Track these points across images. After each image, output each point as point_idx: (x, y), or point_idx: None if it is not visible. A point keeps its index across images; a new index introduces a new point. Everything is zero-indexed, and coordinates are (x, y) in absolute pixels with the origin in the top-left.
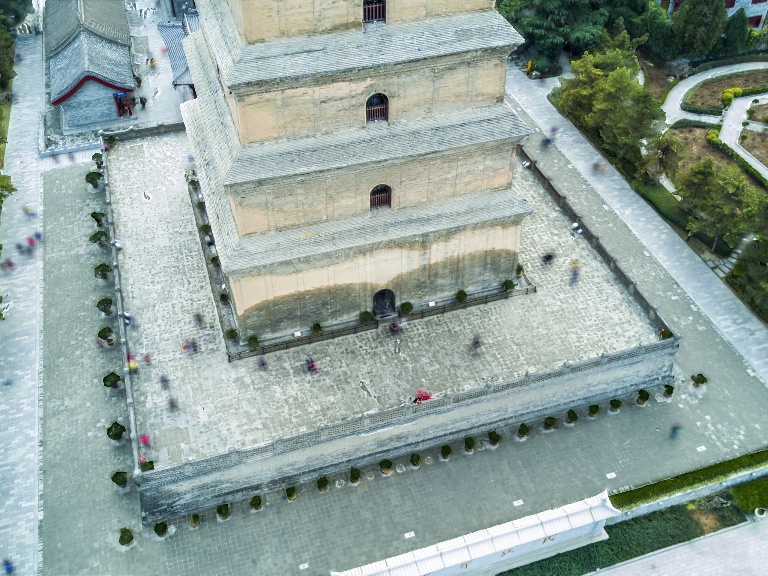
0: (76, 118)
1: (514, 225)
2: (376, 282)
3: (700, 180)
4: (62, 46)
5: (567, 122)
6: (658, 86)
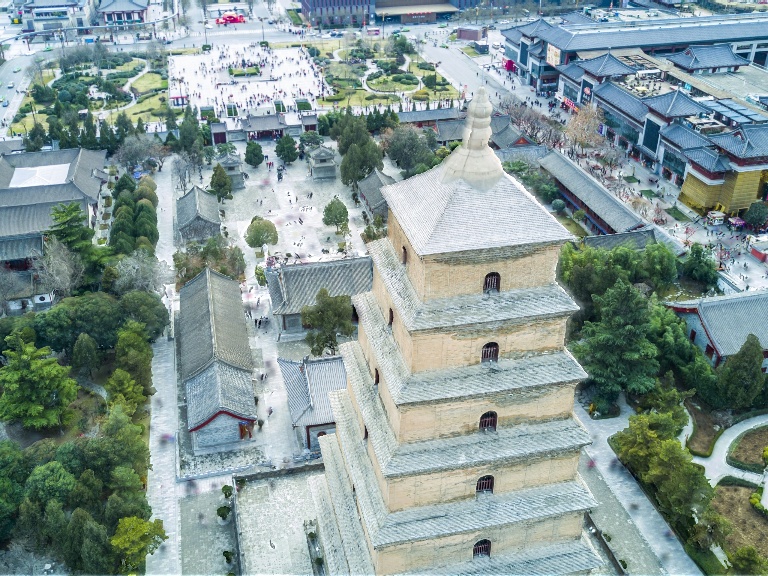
0: (206, 440)
1: None
2: None
3: (745, 566)
4: (198, 372)
5: (626, 471)
6: (705, 435)
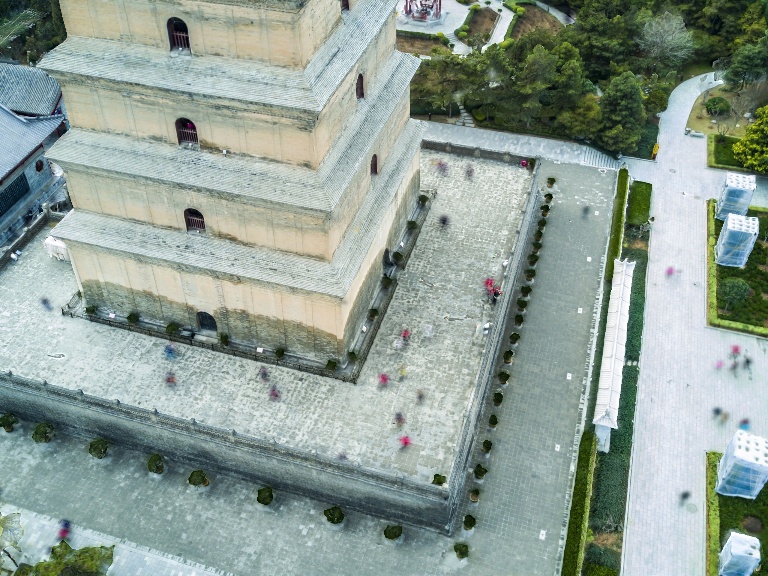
0: None
1: None
2: (383, 247)
3: (420, 71)
4: None
5: None
6: None
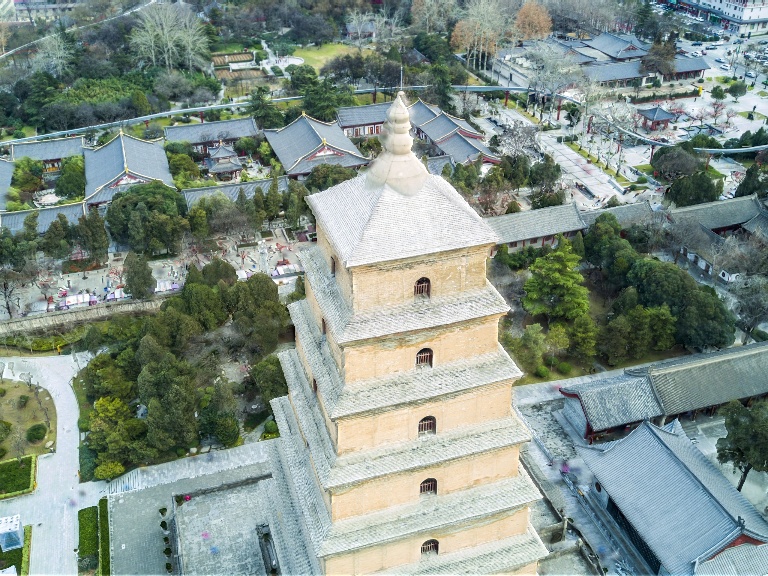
0: None
1: None
2: None
3: None
4: (635, 373)
5: None
6: None
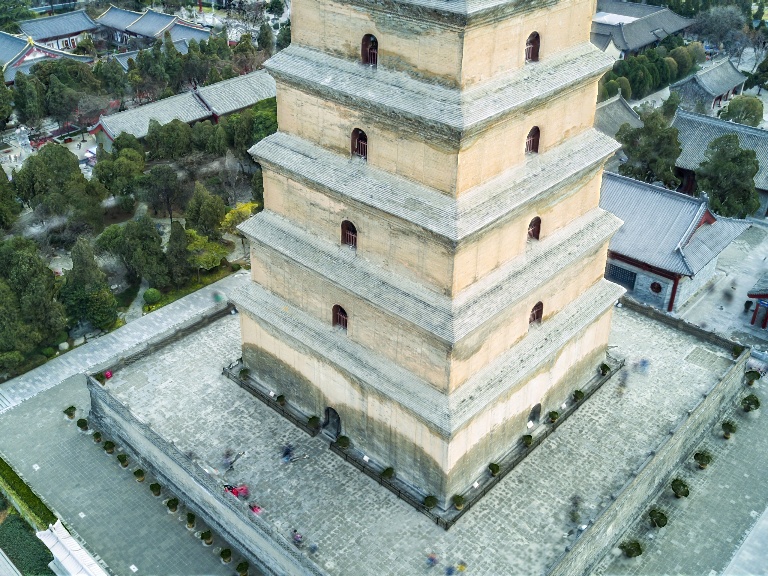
0: None
1: (441, 437)
2: (328, 396)
3: None
4: None
5: None
6: None
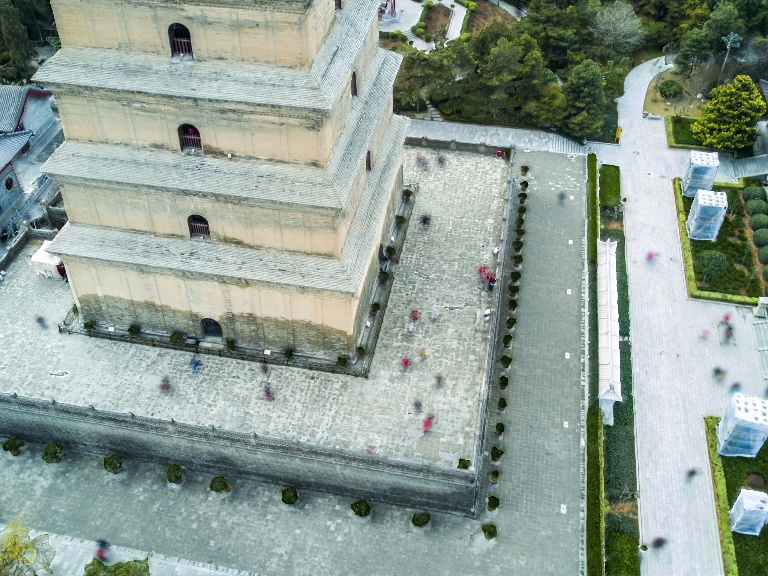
0: None
1: None
2: (378, 242)
3: None
4: None
5: None
6: None
